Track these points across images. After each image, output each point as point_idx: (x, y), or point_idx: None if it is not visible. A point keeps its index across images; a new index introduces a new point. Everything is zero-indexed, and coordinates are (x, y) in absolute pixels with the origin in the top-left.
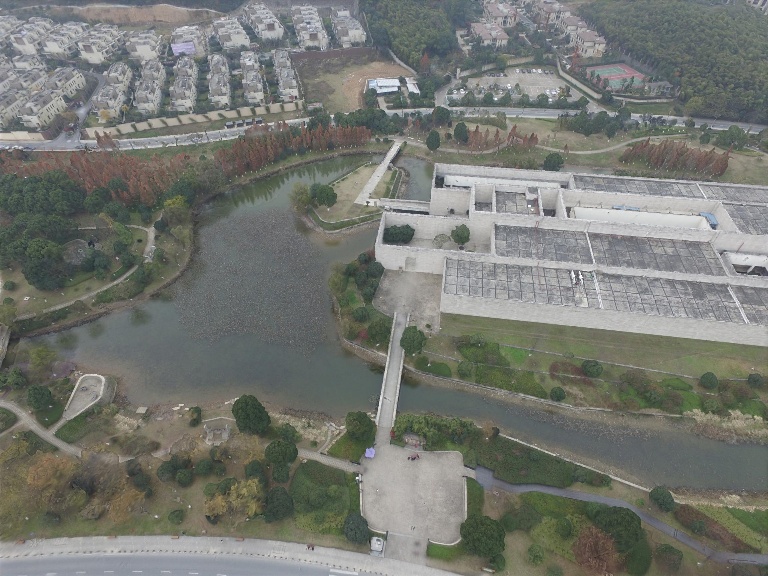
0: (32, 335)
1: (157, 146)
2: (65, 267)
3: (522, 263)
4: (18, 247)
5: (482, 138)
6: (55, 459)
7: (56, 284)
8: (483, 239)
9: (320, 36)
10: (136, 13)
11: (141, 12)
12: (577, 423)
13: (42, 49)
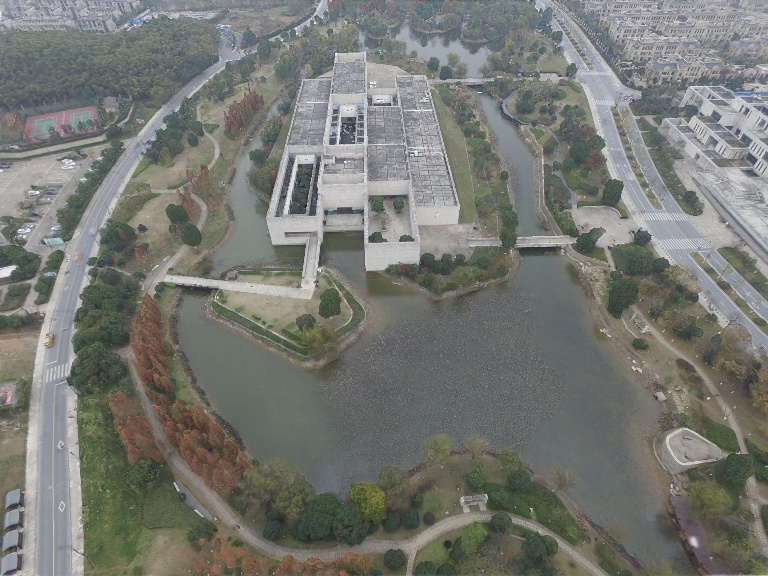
0: None
1: None
2: None
3: None
4: None
5: (191, 201)
6: (763, 399)
7: None
8: None
9: None
10: None
11: None
12: (514, 175)
13: None
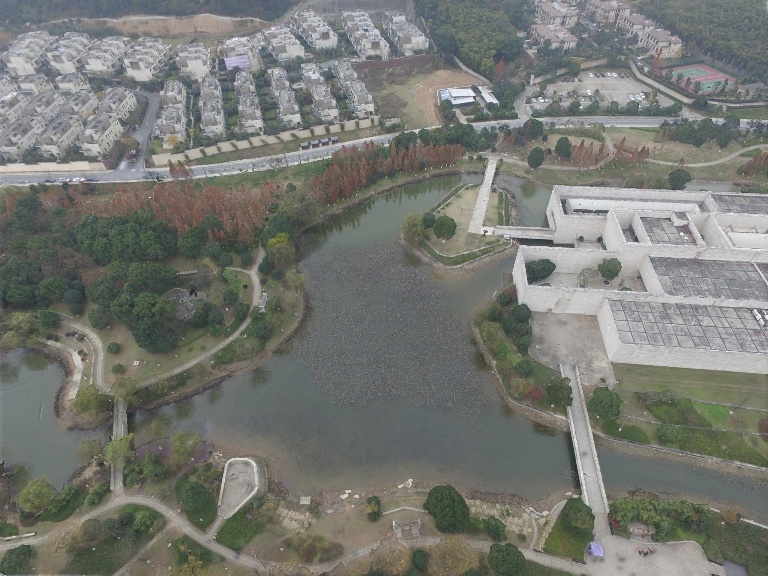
0: (151, 407)
1: (232, 173)
2: (177, 325)
3: (695, 302)
4: (123, 304)
5: (587, 153)
6: None
7: (170, 345)
8: (629, 272)
9: (382, 44)
10: (176, 24)
11: (181, 23)
12: None
13: (83, 67)
